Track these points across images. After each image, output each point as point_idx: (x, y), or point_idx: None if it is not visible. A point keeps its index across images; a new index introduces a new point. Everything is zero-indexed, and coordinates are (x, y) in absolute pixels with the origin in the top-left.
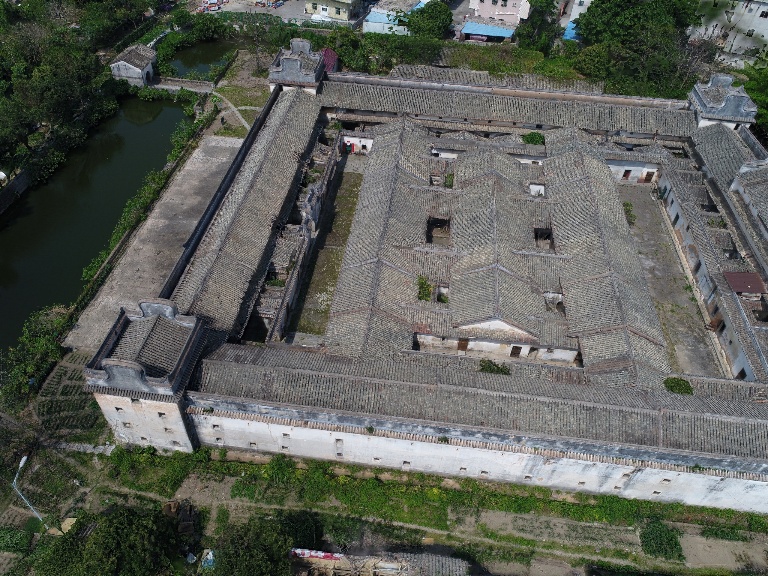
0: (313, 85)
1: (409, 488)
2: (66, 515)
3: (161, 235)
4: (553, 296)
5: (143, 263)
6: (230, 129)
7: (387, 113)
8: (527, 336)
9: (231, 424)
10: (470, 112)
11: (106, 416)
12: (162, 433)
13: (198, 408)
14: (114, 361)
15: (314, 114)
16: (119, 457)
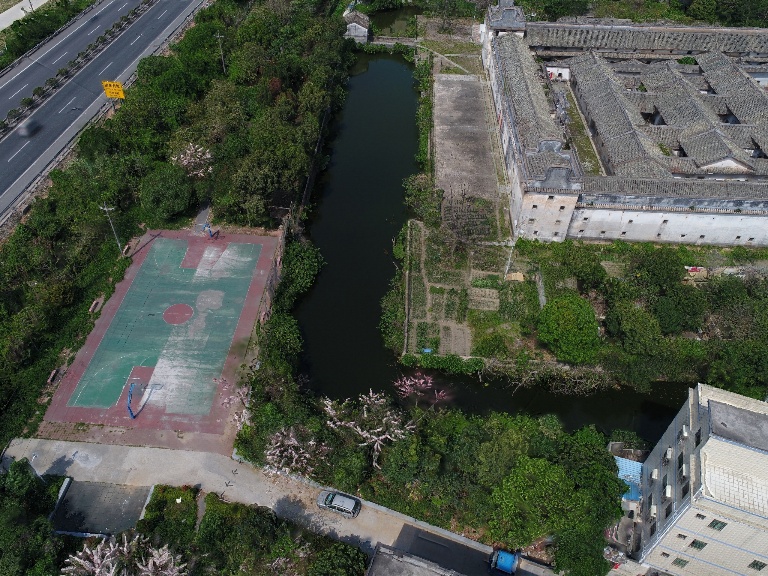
0: (524, 29)
1: (706, 251)
2: (509, 272)
3: (451, 135)
4: (747, 152)
5: (452, 151)
6: (450, 69)
7: (575, 49)
8: (747, 170)
9: (597, 216)
10: (640, 44)
11: (521, 214)
12: (552, 226)
13: (583, 203)
14: (556, 165)
15: (528, 50)
16: (523, 243)
